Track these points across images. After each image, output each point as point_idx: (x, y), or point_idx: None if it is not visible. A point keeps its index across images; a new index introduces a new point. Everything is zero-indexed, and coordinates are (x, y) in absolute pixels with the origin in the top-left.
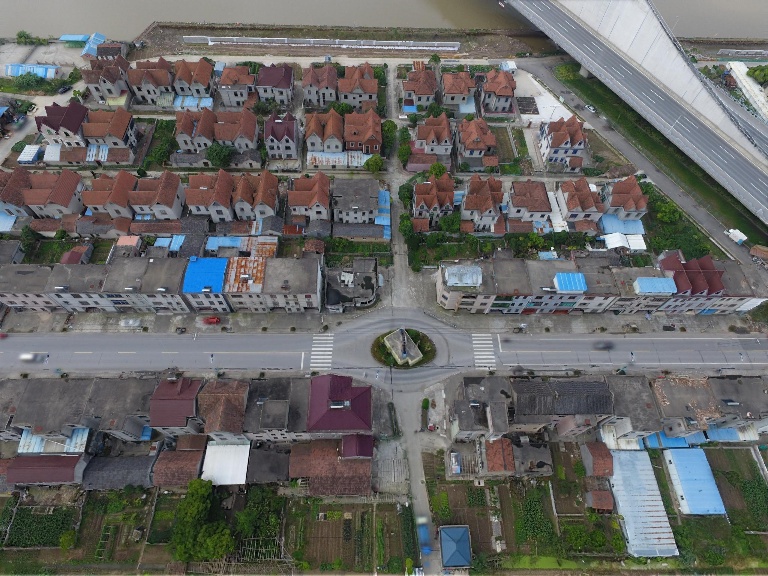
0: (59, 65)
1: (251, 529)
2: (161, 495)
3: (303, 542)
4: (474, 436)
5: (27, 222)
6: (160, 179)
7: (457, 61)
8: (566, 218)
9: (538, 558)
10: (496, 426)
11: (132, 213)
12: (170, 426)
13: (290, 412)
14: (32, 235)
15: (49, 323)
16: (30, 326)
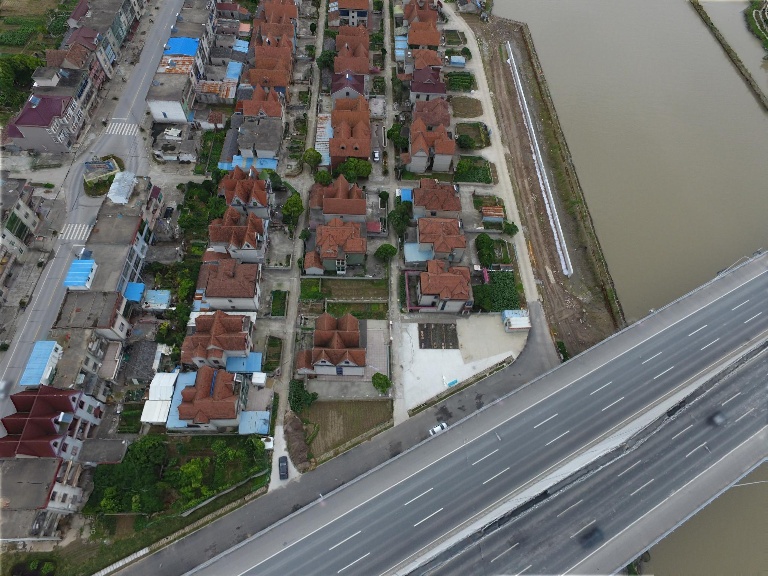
0: None
1: None
2: None
3: None
4: None
5: None
6: None
7: None
8: None
9: None
10: None
11: None
12: None
13: (51, 87)
14: None
15: None
16: None
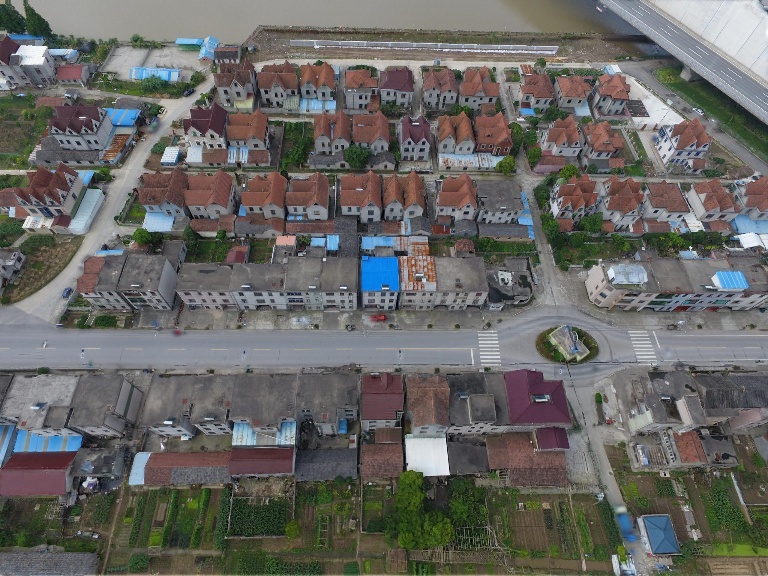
0: (177, 68)
1: (462, 518)
2: (365, 486)
3: (511, 531)
4: (659, 429)
5: (185, 222)
6: (312, 180)
7: (561, 65)
8: (702, 218)
9: (734, 546)
10: (695, 419)
11: (285, 214)
12: (381, 419)
13: None
14: (193, 235)
15: (223, 321)
16: (205, 324)
